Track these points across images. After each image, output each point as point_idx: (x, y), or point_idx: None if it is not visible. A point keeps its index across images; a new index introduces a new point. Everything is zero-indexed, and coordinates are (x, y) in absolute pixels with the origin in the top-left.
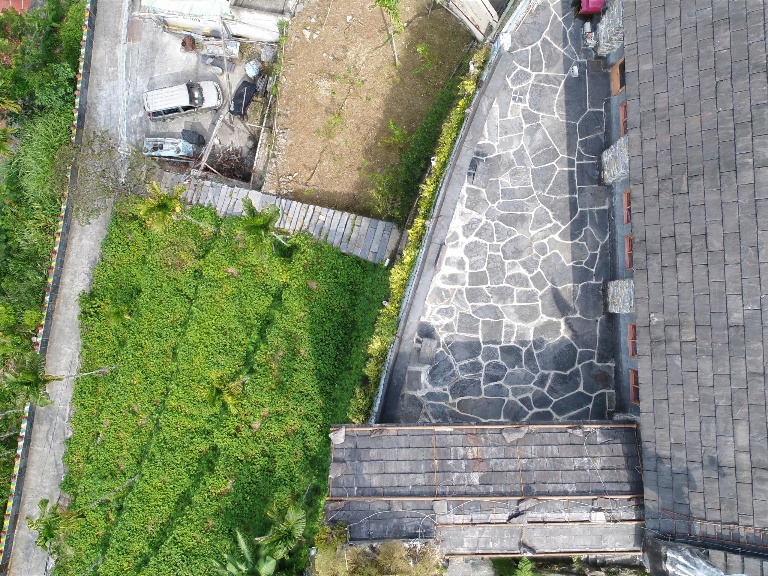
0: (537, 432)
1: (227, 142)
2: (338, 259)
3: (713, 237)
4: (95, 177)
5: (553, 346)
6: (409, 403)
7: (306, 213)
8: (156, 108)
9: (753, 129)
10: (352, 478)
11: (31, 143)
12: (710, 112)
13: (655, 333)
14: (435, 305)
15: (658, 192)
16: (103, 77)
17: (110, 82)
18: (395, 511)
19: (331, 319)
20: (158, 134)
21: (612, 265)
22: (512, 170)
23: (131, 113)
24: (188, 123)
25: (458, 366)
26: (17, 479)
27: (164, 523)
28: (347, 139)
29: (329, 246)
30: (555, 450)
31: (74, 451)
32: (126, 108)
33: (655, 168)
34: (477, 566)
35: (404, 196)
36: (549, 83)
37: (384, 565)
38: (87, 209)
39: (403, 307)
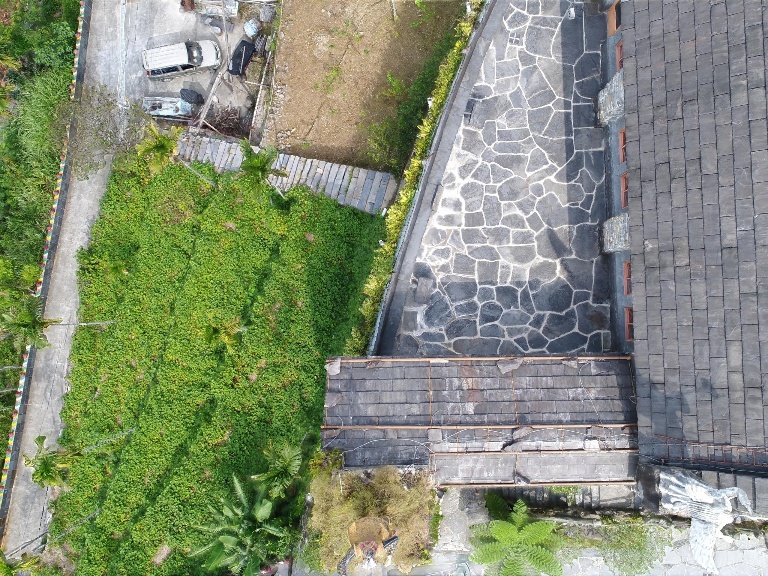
0: (532, 364)
1: (226, 102)
2: (335, 211)
3: (707, 160)
4: (94, 130)
5: (549, 287)
6: (405, 343)
7: (304, 166)
8: (155, 66)
9: (747, 51)
10: (347, 408)
11: (30, 101)
12: (705, 36)
13: (649, 260)
14: (431, 246)
15: (653, 119)
16: (102, 37)
17: (109, 42)
18: (390, 439)
19: (328, 271)
20: (157, 94)
21: (608, 206)
22: (508, 112)
23: (130, 73)
24: (187, 83)
25: (454, 306)
26: (15, 435)
27: (161, 475)
28: (345, 94)
29: (326, 198)
30: (550, 381)
31: (72, 406)
32: (125, 62)
33: (650, 96)
34: (473, 514)
35: (401, 145)
36: (546, 25)
37: (379, 489)
38: (85, 164)
39: (399, 247)
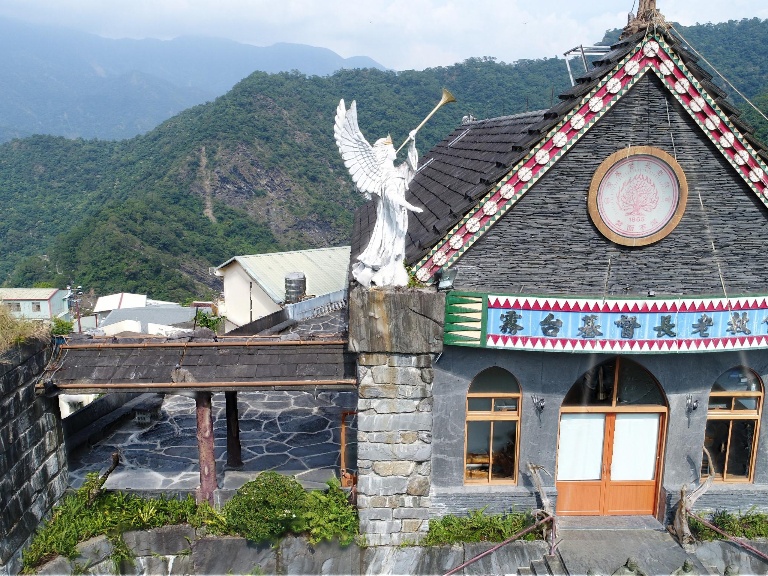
0: None
1: None
2: None
3: None
4: None
5: (301, 420)
6: (102, 450)
7: None
8: None
9: None
10: None
11: None
12: None
13: None
14: None
15: None
16: None
17: None
18: None
19: None
20: None
21: None
22: None
23: None
24: None
25: (181, 430)
26: None
27: None
28: None
29: None
30: None
31: None
32: None
33: None
34: None
35: None
36: None
37: None
38: None
39: None
